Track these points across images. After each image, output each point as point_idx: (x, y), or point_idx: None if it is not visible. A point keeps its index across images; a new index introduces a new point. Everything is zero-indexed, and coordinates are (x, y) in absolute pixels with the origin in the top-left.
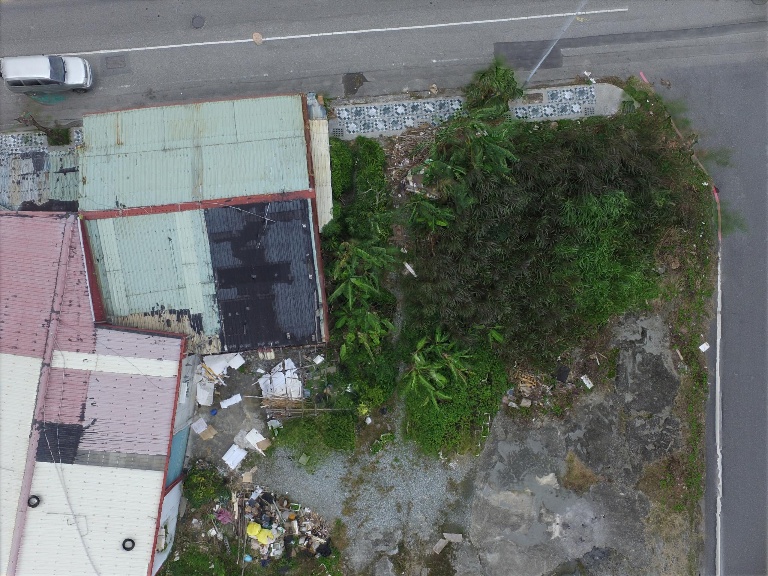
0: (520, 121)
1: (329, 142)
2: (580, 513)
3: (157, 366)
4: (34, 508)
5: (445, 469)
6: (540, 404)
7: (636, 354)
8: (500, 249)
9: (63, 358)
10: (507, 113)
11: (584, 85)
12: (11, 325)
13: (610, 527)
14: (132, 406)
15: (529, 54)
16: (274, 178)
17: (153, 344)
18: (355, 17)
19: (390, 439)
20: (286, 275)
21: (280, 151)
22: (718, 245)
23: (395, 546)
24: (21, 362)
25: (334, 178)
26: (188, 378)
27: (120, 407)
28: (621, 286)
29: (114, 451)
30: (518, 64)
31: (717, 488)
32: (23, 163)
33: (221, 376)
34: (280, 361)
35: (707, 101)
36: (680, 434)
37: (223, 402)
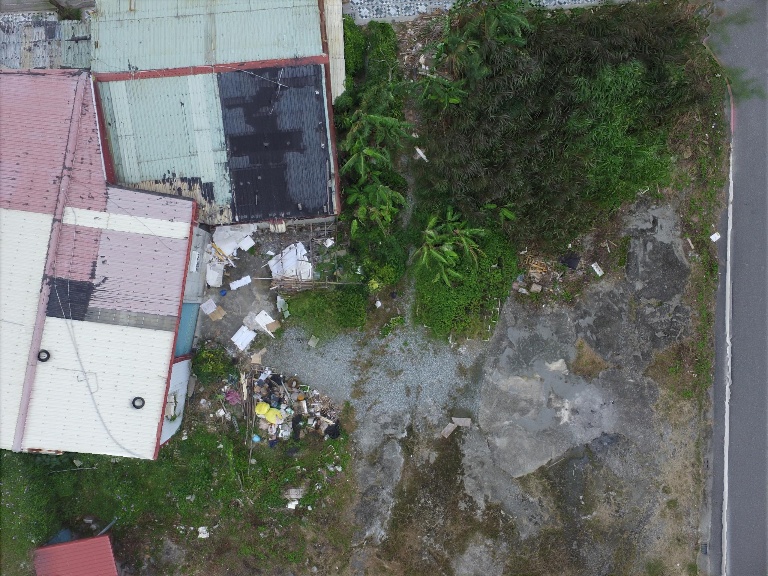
0: (533, 9)
1: (342, 15)
2: (589, 399)
3: (168, 227)
4: (44, 362)
5: (454, 354)
6: (550, 290)
7: (647, 243)
8: (513, 124)
9: (74, 215)
10: None
11: None
12: (22, 182)
13: (619, 413)
14: (143, 266)
15: None
16: (287, 44)
17: (165, 205)
18: None
19: (400, 322)
20: (298, 143)
21: (293, 20)
22: (730, 136)
23: (403, 429)
24: (32, 218)
25: (347, 51)
26: (198, 252)
27: (131, 266)
28: (634, 162)
29: (125, 310)
30: None
31: (726, 376)
32: (35, 31)
33: (231, 257)
34: (290, 244)
35: None
36: (690, 322)
37: (232, 283)
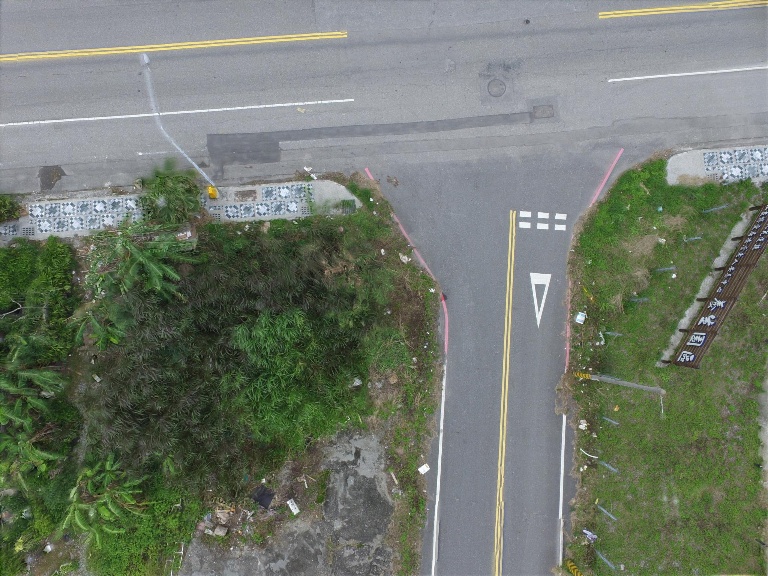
0: (230, 221)
1: None
2: None
3: None
4: None
5: None
6: (238, 532)
7: (348, 477)
8: (169, 372)
9: None
10: (216, 212)
11: (302, 182)
12: None
13: None
14: None
15: (245, 147)
16: None
17: None
18: (54, 105)
19: (70, 570)
20: None
21: None
22: (444, 357)
23: None
24: None
25: None
26: None
27: None
28: (298, 416)
29: None
30: (233, 158)
31: None
32: None
33: None
34: None
35: (437, 200)
36: (391, 566)
37: None
